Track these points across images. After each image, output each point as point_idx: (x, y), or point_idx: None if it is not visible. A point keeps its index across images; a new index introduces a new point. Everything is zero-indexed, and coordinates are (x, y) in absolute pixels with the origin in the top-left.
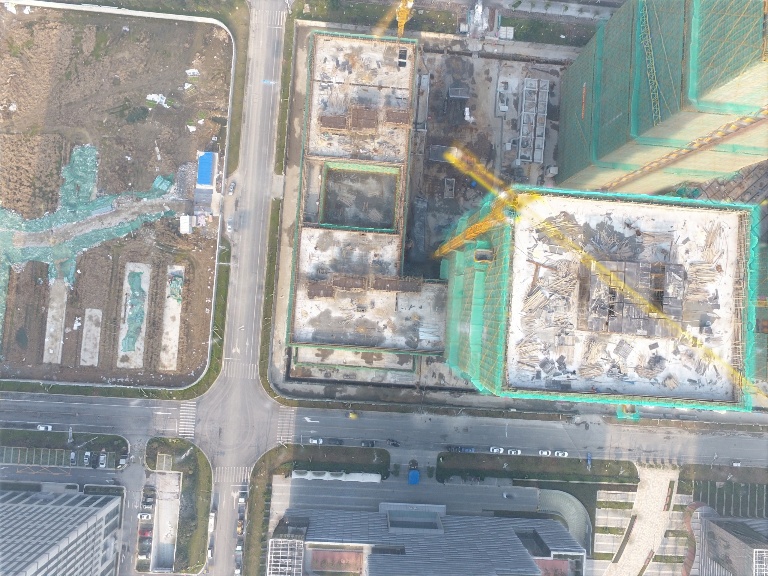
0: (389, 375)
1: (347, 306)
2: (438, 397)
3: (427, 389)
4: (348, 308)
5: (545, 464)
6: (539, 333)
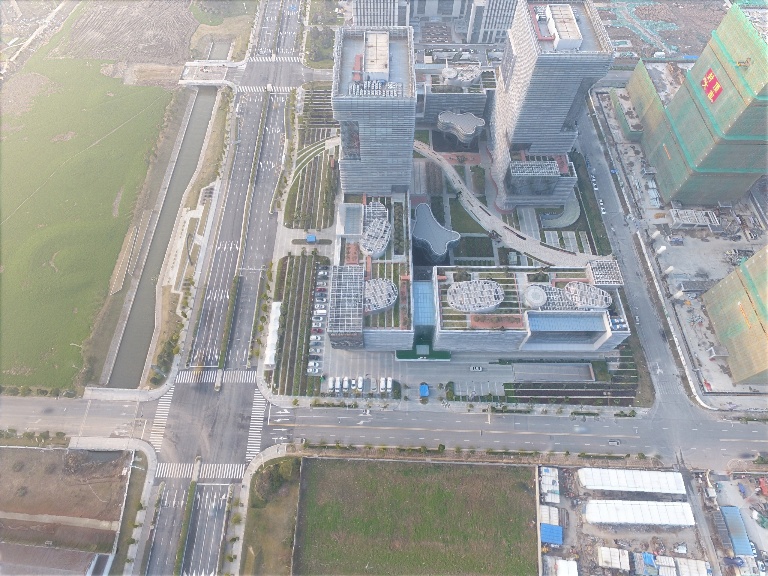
0: (617, 131)
1: (669, 79)
2: (613, 152)
3: (616, 146)
4: (669, 80)
5: (593, 203)
6: (764, 16)
